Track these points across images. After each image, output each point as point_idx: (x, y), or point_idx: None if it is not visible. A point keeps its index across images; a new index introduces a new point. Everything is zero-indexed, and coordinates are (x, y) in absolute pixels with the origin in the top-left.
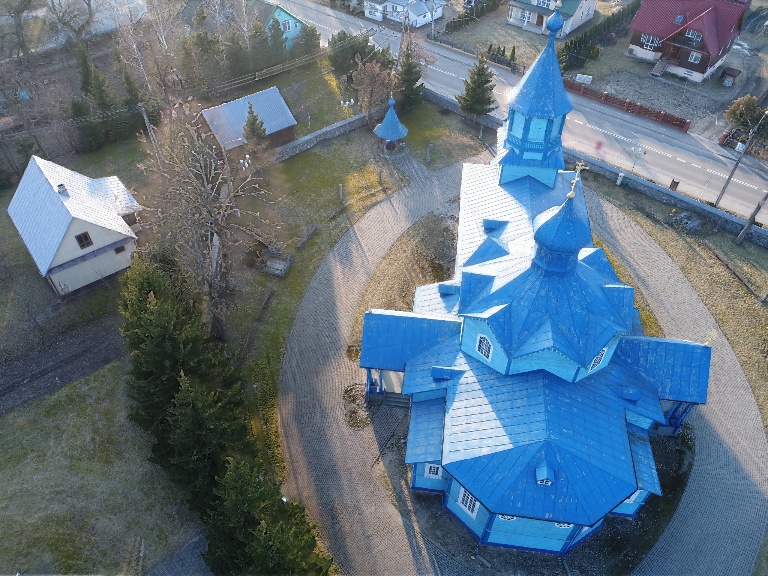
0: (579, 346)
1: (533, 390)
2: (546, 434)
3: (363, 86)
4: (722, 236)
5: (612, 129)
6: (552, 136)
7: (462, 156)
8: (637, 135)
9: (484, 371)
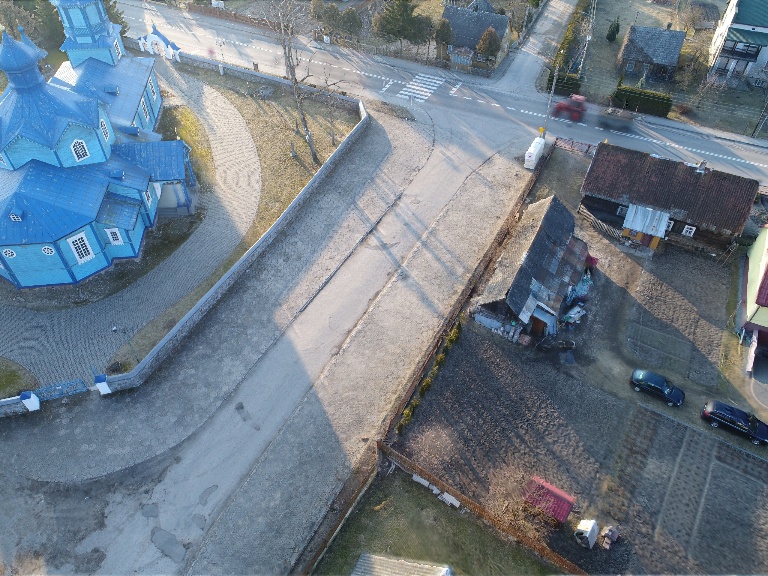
0: (48, 136)
1: (23, 171)
2: (16, 189)
3: (2, 21)
4: (287, 98)
5: (235, 39)
6: (94, 23)
7: None
8: (253, 40)
9: (5, 173)
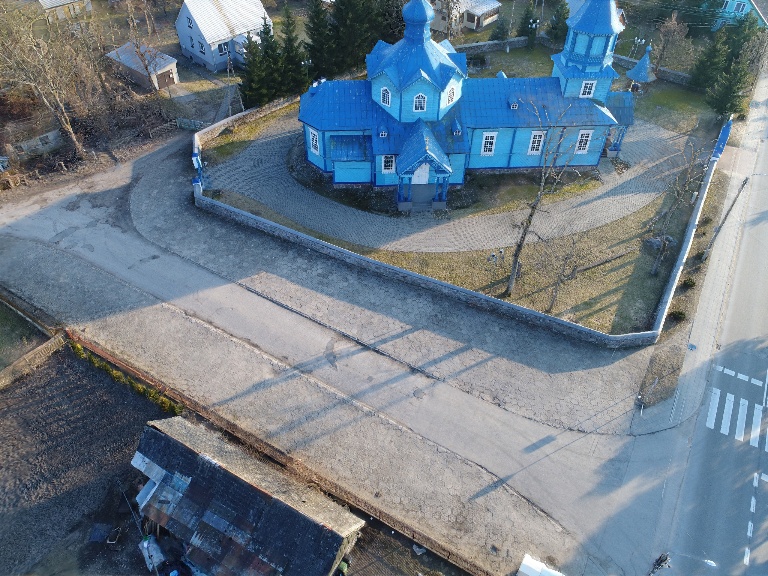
0: None
1: None
2: None
3: None
4: None
5: None
6: (579, 52)
7: (657, 123)
8: None
9: None
